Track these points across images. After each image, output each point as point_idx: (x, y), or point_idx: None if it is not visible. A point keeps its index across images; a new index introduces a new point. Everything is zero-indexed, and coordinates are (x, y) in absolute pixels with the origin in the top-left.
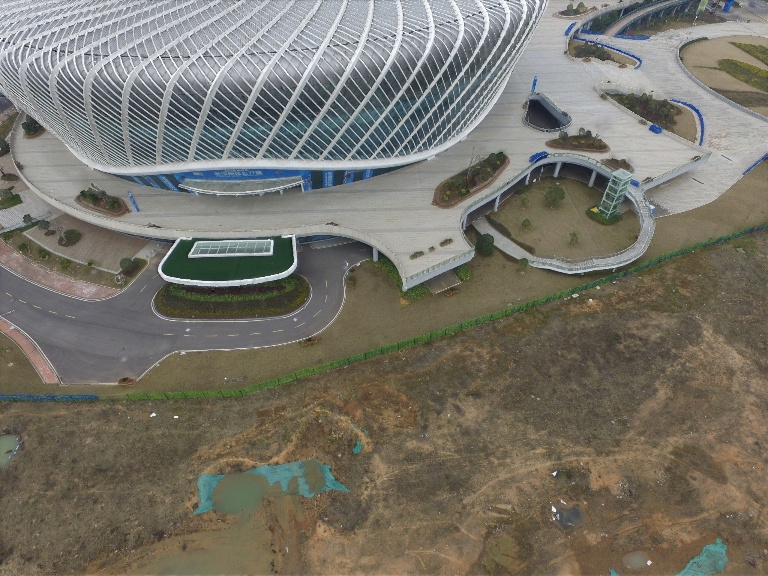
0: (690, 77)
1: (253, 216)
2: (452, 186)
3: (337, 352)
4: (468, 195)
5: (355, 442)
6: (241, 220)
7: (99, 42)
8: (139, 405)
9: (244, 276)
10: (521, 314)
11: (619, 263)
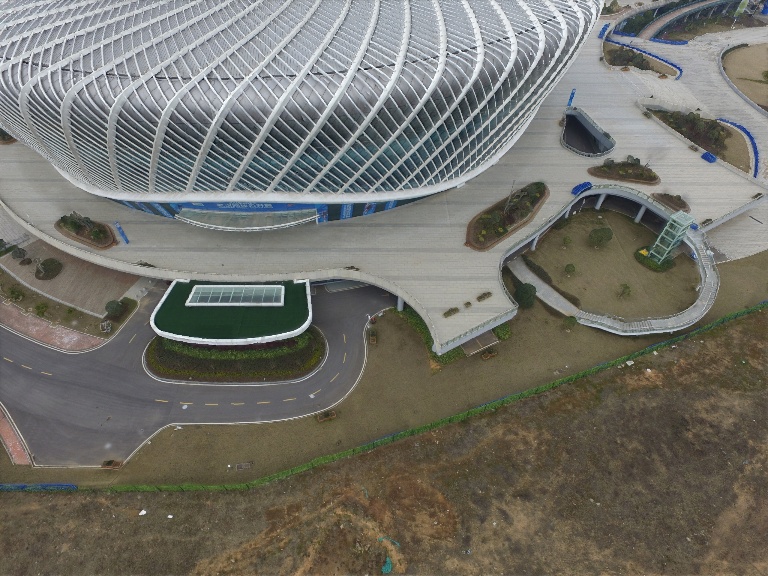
0: (736, 92)
1: (260, 254)
2: (488, 224)
3: (359, 431)
4: (506, 235)
5: (384, 558)
6: (247, 259)
7: (80, 54)
8: (126, 499)
9: (251, 333)
10: (570, 386)
11: (680, 326)
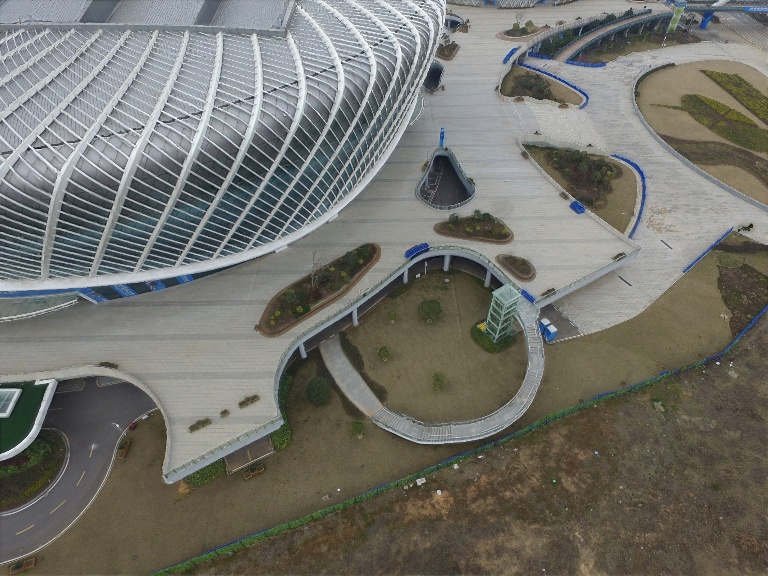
0: (642, 121)
1: (12, 345)
2: (285, 303)
3: None
4: (307, 314)
5: None
6: None
7: None
8: None
9: None
10: (336, 517)
11: (485, 433)
